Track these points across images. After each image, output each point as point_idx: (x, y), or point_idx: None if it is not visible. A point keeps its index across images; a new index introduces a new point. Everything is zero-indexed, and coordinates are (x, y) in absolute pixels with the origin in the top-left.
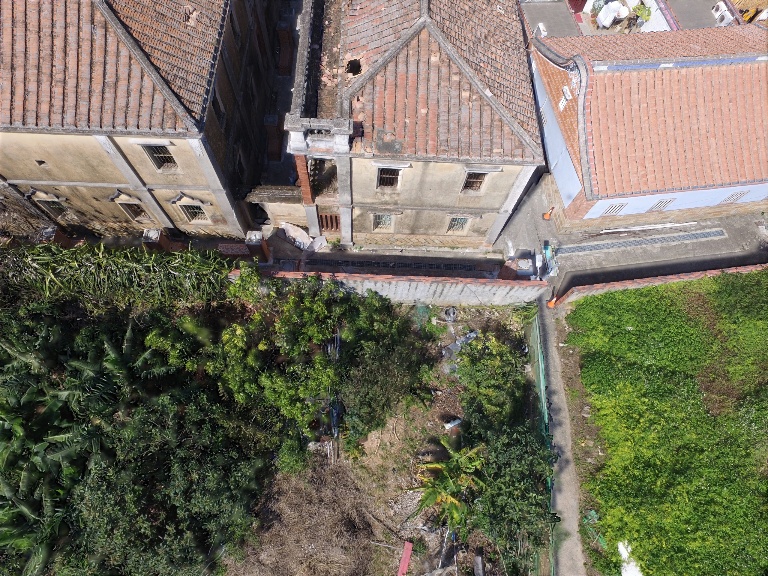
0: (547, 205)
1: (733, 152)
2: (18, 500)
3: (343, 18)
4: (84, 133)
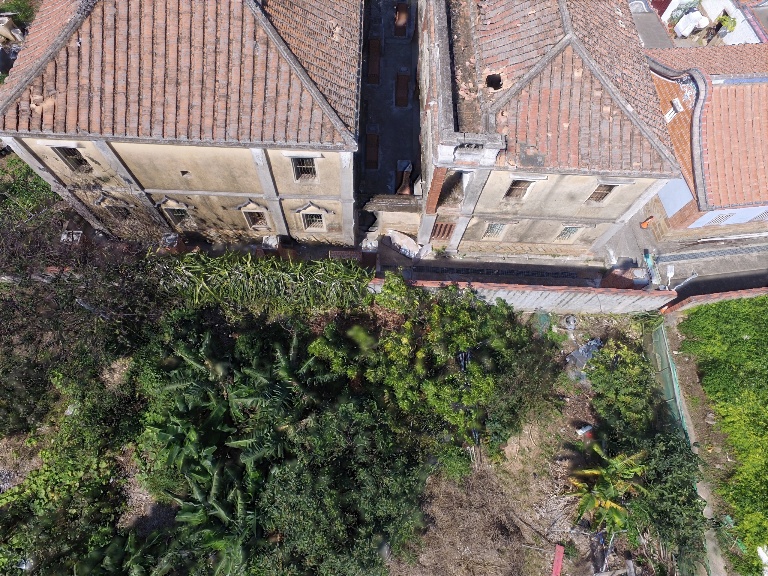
0: (643, 214)
1: None
2: (217, 503)
3: (475, 33)
4: (245, 146)
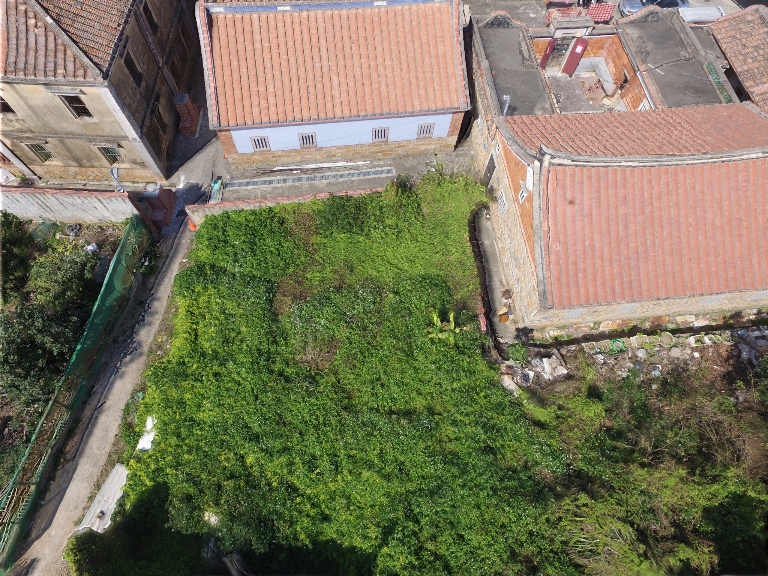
0: None
1: (355, 89)
2: None
3: None
4: None
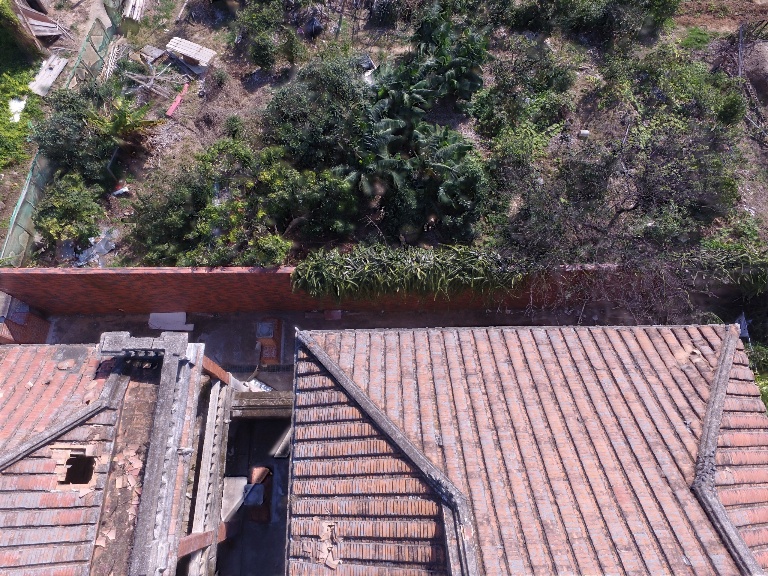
0: None
1: None
2: (400, 84)
3: None
4: None
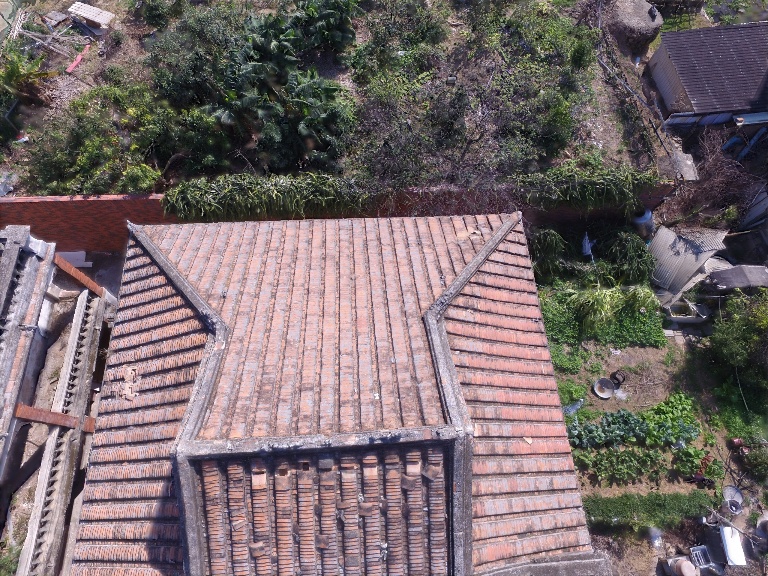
0: None
1: None
2: (267, 32)
3: None
4: None
